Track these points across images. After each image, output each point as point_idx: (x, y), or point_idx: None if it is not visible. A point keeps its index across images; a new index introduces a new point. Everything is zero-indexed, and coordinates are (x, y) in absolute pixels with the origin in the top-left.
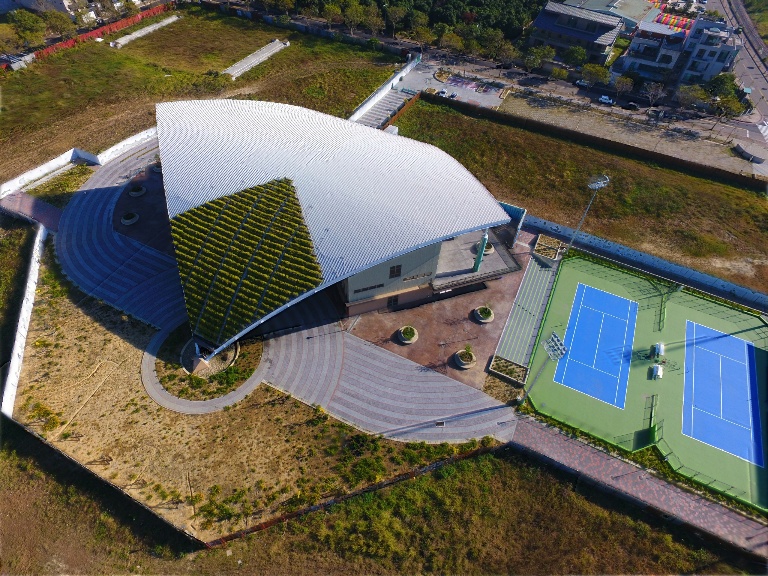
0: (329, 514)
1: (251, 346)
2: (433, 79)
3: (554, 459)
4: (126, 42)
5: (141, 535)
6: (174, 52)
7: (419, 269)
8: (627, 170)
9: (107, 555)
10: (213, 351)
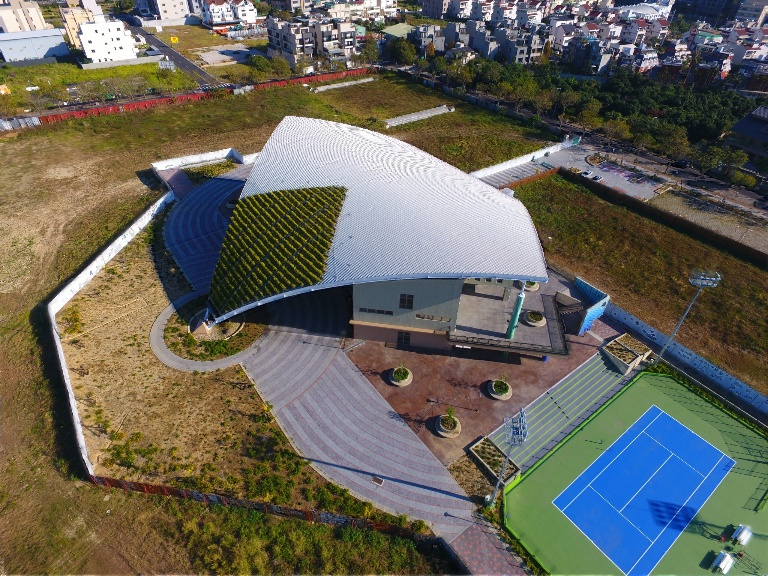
0: (209, 512)
1: (252, 330)
2: (583, 161)
3: None
4: (323, 90)
5: (59, 444)
6: (354, 101)
7: (435, 309)
8: None
9: (28, 447)
10: (215, 319)
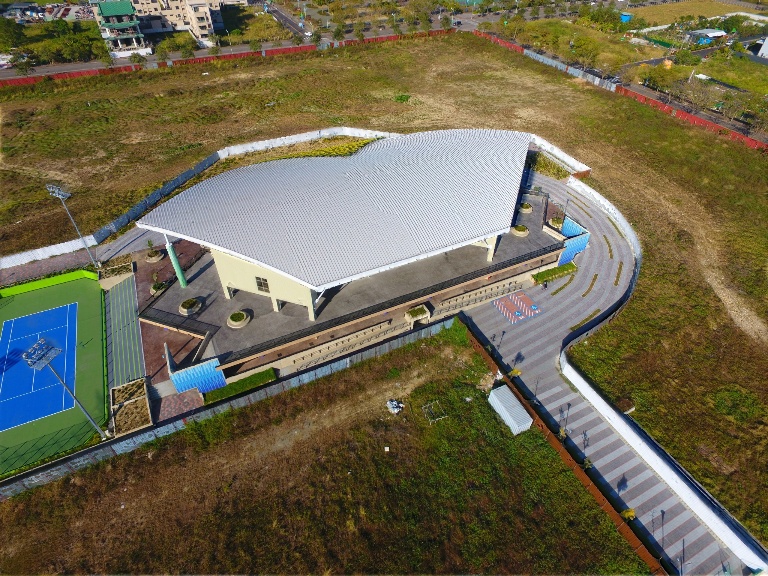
0: None
1: None
2: None
3: (61, 258)
4: None
5: None
6: None
7: None
8: None
9: None
10: None
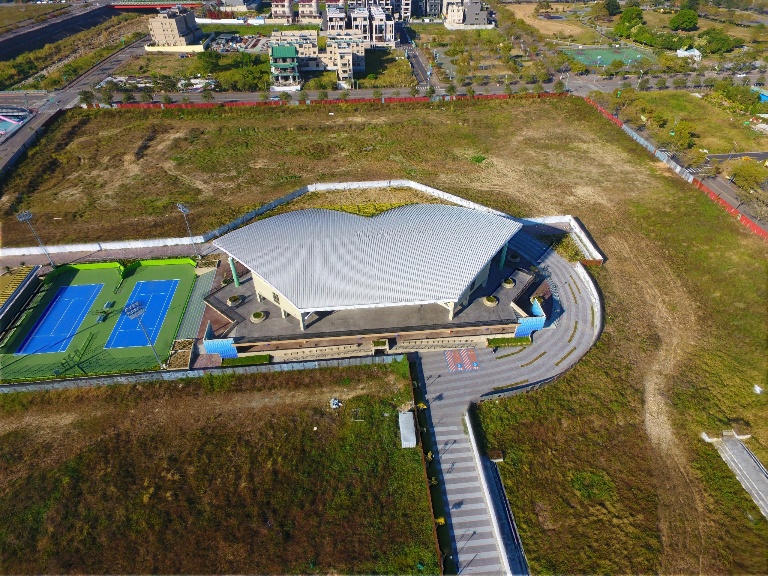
0: None
1: None
2: None
3: (181, 247)
4: None
5: None
6: None
7: None
8: (40, 562)
9: None
10: None
